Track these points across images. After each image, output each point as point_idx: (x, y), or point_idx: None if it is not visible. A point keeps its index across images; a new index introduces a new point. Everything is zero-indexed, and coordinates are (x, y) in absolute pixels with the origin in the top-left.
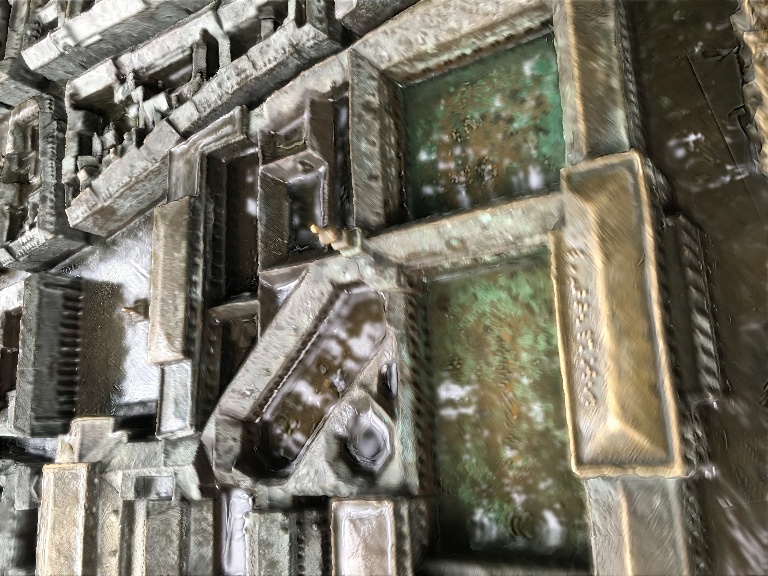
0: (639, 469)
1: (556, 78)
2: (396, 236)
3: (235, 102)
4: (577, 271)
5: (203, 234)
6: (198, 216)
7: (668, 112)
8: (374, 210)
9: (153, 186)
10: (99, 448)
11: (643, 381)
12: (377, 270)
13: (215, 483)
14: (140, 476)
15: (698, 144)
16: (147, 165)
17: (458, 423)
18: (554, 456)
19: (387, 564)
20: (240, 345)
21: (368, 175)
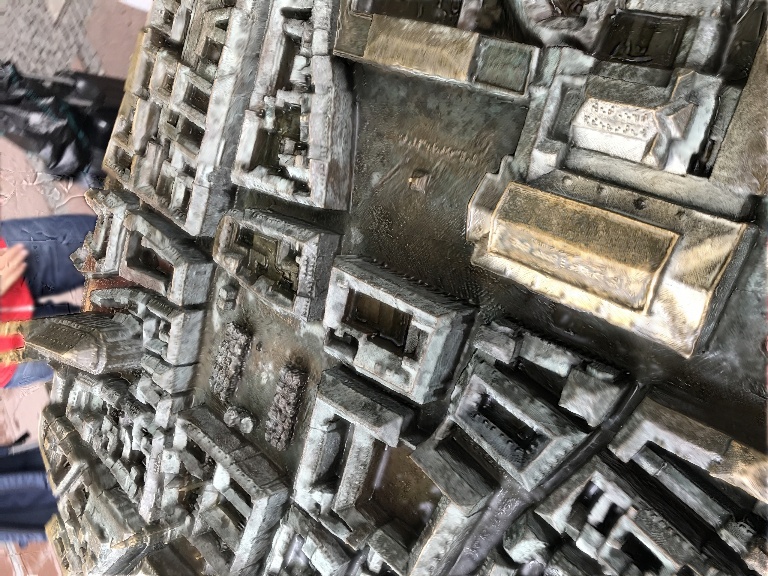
0: None
1: None
2: None
3: (337, 4)
4: None
5: None
6: None
7: None
8: None
9: (343, 116)
10: None
11: None
12: None
13: None
14: (547, 133)
15: None
16: (329, 97)
17: None
18: None
19: None
20: (497, 18)
21: None
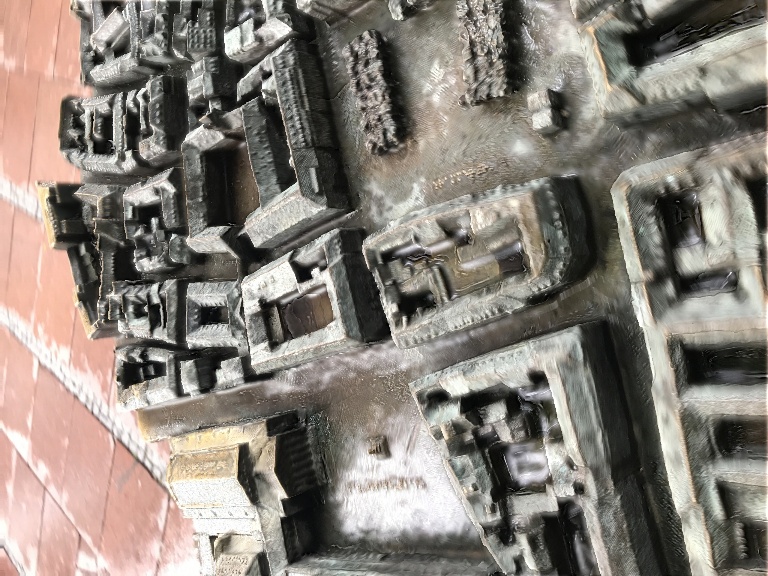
0: None
1: None
2: None
3: None
4: None
5: None
6: None
7: None
8: None
9: None
10: (268, 490)
11: None
12: None
13: None
14: None
15: None
16: (472, 520)
17: None
18: None
19: None
20: None
21: None
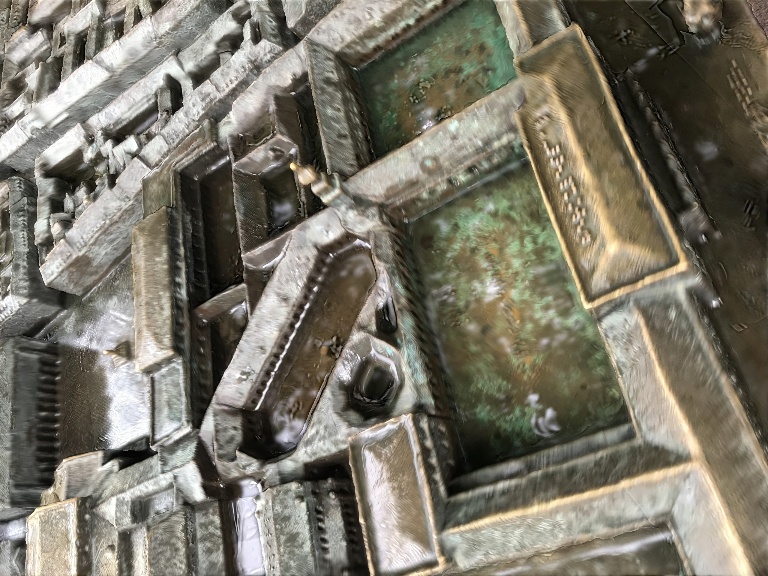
0: (647, 277)
1: (494, 27)
2: (372, 169)
3: None
4: (547, 133)
5: (182, 240)
6: (176, 225)
7: (597, 22)
8: (348, 163)
9: (127, 228)
10: (88, 485)
11: (630, 200)
12: (359, 211)
13: (219, 482)
14: (136, 497)
15: (629, 38)
16: (120, 205)
17: (463, 346)
18: (564, 344)
19: (415, 476)
20: (230, 339)
21: (337, 135)
